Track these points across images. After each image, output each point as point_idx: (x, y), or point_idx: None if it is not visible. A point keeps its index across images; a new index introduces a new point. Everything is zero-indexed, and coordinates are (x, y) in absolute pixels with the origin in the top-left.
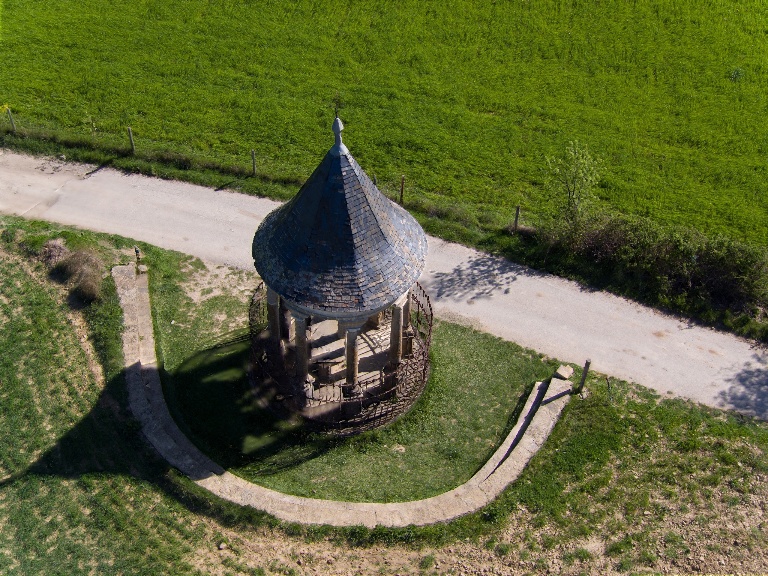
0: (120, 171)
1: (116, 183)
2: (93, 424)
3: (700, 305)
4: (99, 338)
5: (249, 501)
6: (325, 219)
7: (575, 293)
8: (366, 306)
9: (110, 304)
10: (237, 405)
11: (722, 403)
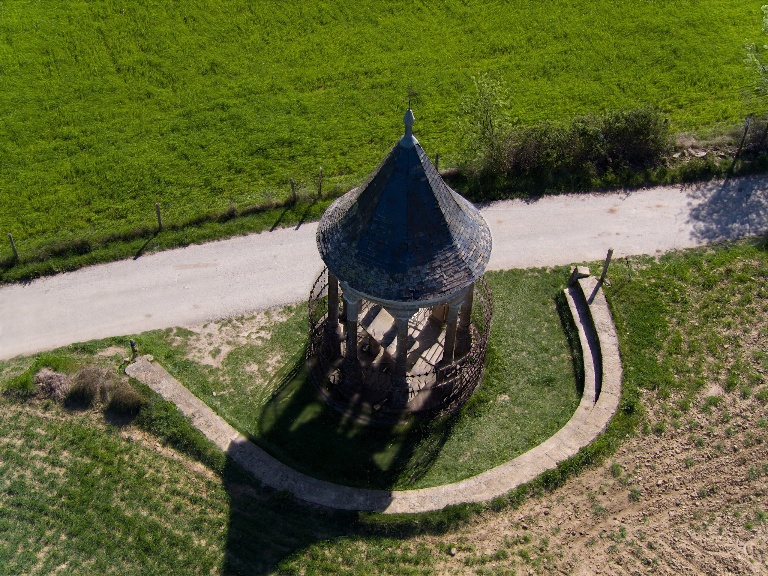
0: (17, 283)
1: (24, 296)
2: (245, 516)
3: (626, 174)
4: (177, 439)
5: (442, 503)
6: (416, 211)
7: (525, 208)
8: (475, 275)
9: (158, 403)
10: (341, 434)
11: (699, 241)
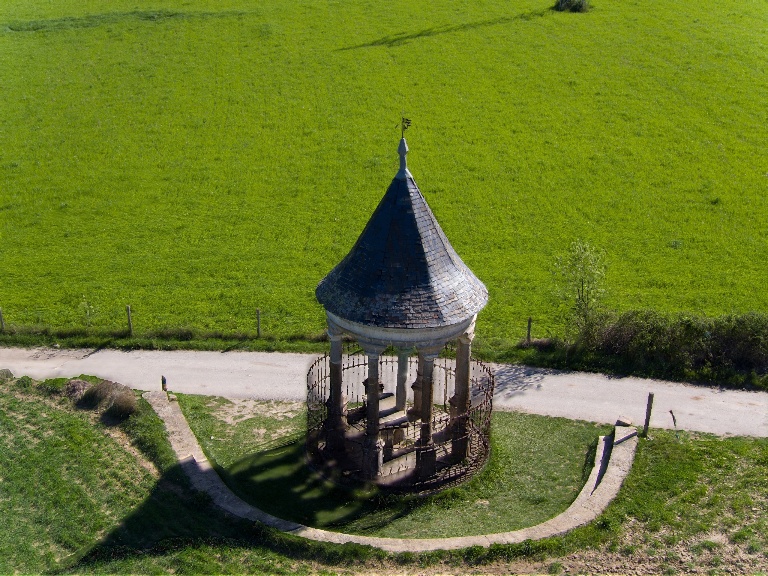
0: (119, 350)
1: (118, 358)
2: (158, 503)
3: (726, 372)
4: (145, 441)
5: (348, 541)
6: (396, 241)
7: (604, 380)
8: (446, 321)
9: (149, 416)
10: (302, 488)
11: None
